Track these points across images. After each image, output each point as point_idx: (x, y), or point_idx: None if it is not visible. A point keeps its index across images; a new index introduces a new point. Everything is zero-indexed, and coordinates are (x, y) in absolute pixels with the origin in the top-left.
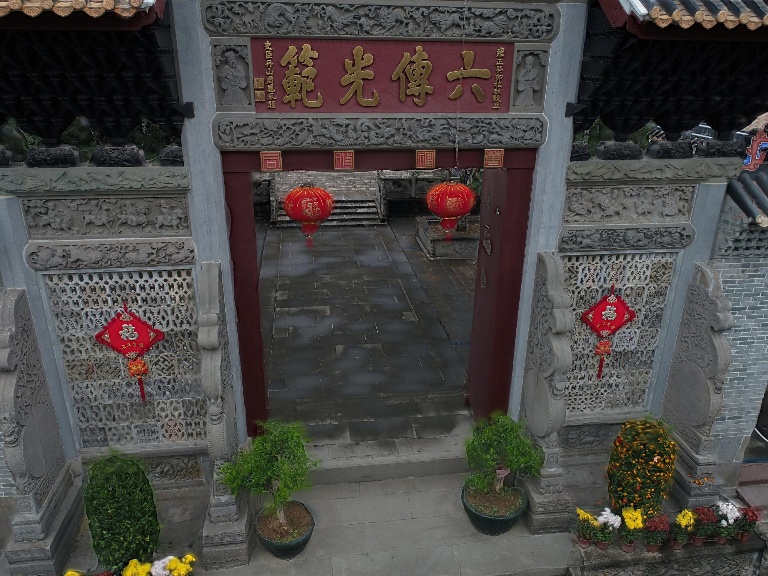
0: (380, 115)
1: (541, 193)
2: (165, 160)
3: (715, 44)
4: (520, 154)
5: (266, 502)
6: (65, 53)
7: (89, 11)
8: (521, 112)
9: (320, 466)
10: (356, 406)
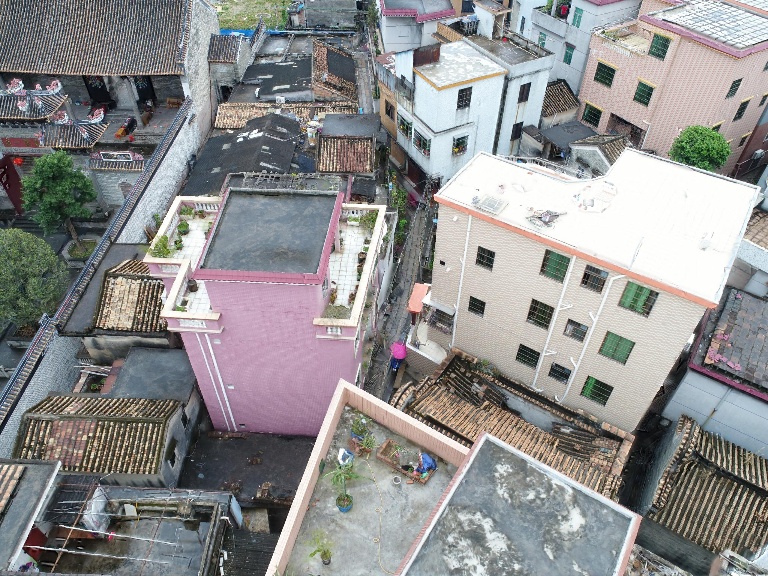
0: None
1: None
2: None
3: None
4: None
5: None
6: None
7: None
8: None
9: None
10: None
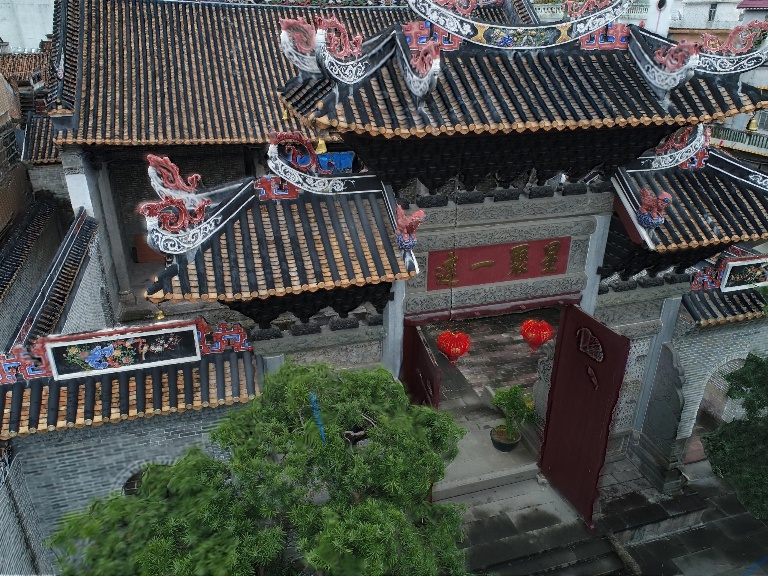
0: None
1: None
2: None
3: None
4: None
5: (529, 461)
6: None
7: None
8: None
9: (509, 470)
10: (527, 567)
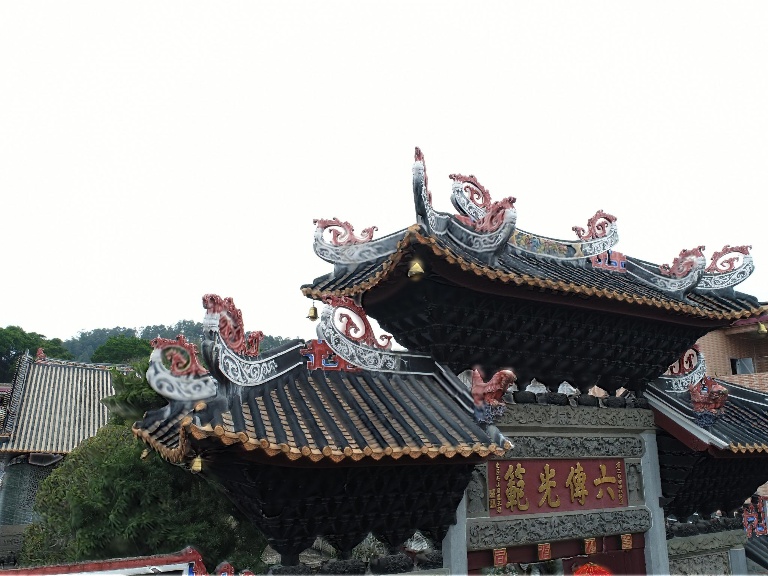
0: (562, 513)
1: (657, 567)
2: (430, 563)
3: (736, 459)
4: (636, 537)
5: None
6: (413, 479)
7: (481, 453)
8: (634, 505)
9: None
10: None
